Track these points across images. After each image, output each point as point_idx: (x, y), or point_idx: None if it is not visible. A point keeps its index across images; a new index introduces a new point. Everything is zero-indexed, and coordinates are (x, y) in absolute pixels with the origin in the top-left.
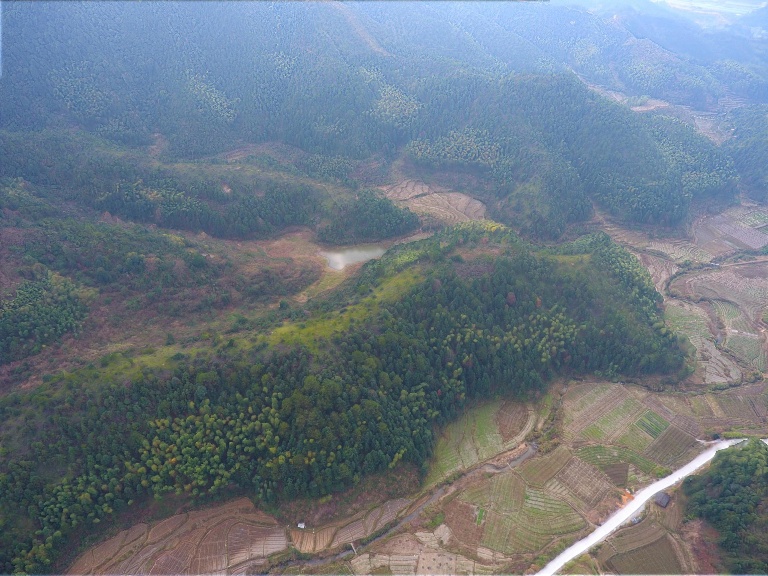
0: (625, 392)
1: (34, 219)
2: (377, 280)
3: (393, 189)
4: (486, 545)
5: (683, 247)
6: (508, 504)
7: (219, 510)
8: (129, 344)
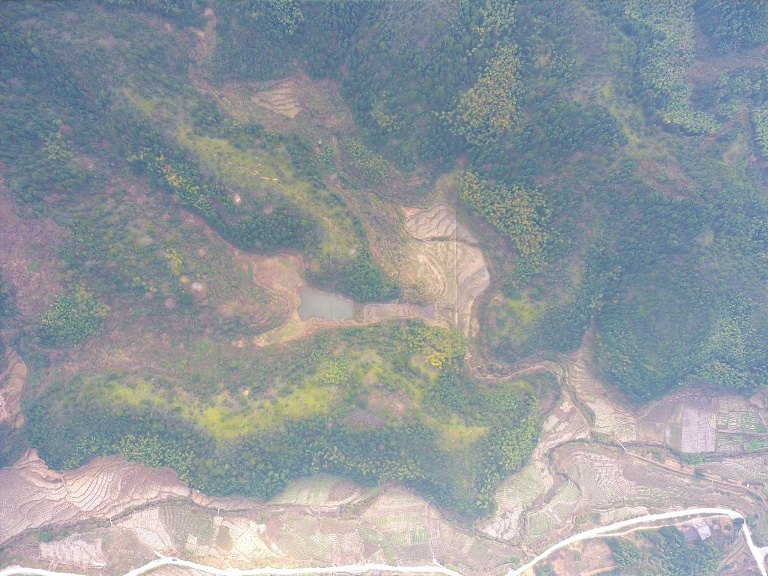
0: (424, 511)
1: (70, 193)
2: (301, 384)
3: (417, 216)
4: (278, 544)
5: (620, 418)
6: (302, 533)
7: None
8: (126, 359)
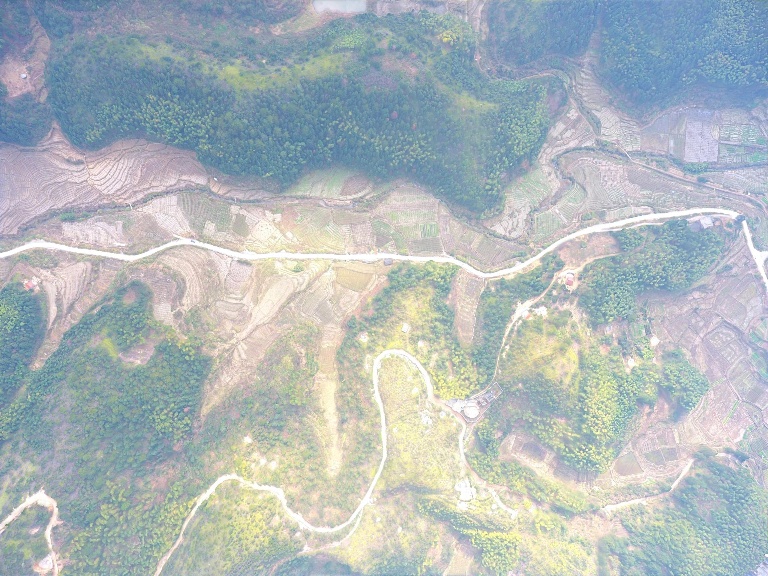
0: (434, 207)
1: None
2: (317, 51)
3: None
4: (293, 232)
5: (625, 127)
6: (316, 223)
7: (181, 151)
8: (147, 27)
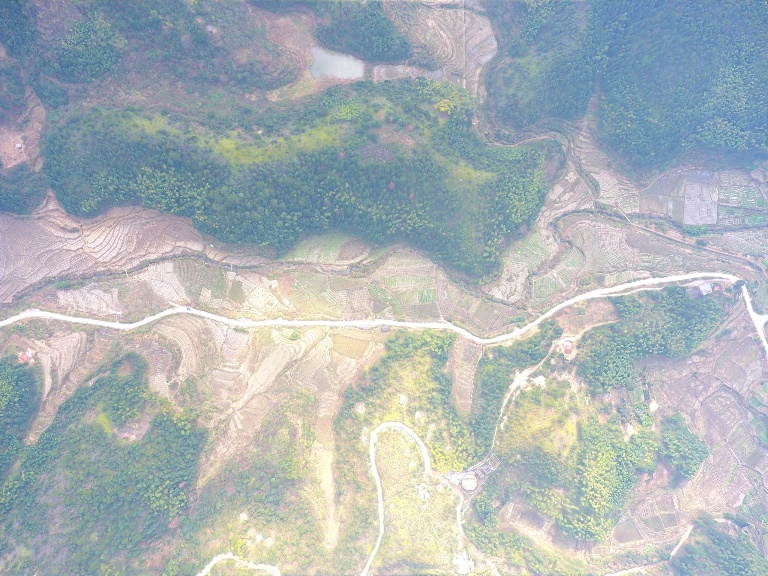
0: (432, 272)
1: None
2: (313, 122)
3: None
4: (289, 299)
5: (624, 189)
6: (313, 289)
7: (177, 218)
8: (143, 98)
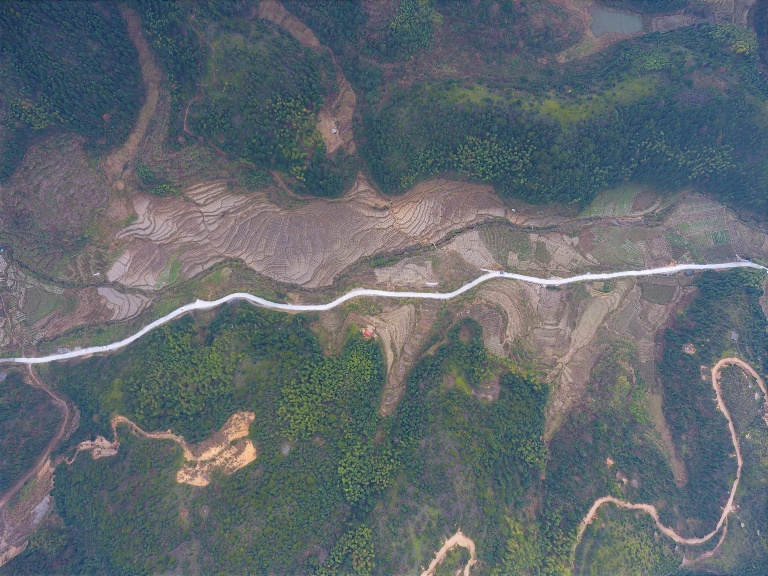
0: (723, 213)
1: None
2: (622, 76)
3: None
4: (592, 254)
5: None
6: (613, 242)
7: (478, 187)
8: (455, 71)
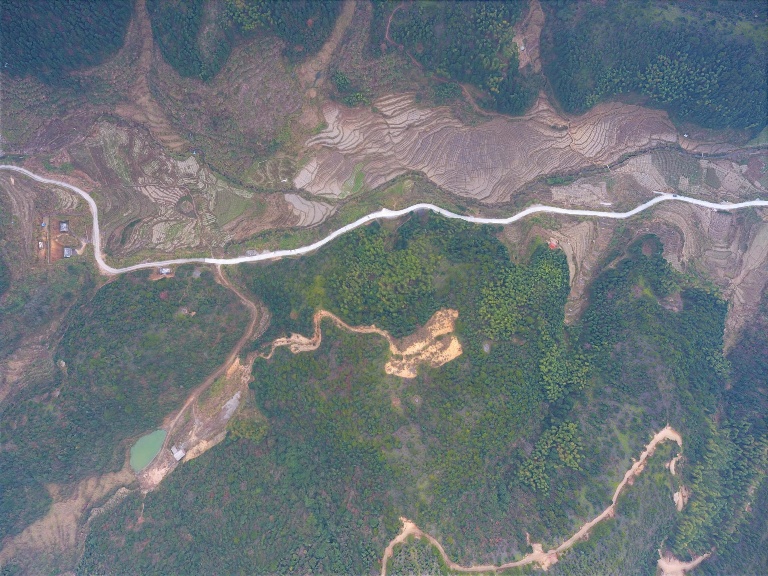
0: None
1: None
2: None
3: None
4: (760, 181)
5: None
6: None
7: (653, 112)
8: None
